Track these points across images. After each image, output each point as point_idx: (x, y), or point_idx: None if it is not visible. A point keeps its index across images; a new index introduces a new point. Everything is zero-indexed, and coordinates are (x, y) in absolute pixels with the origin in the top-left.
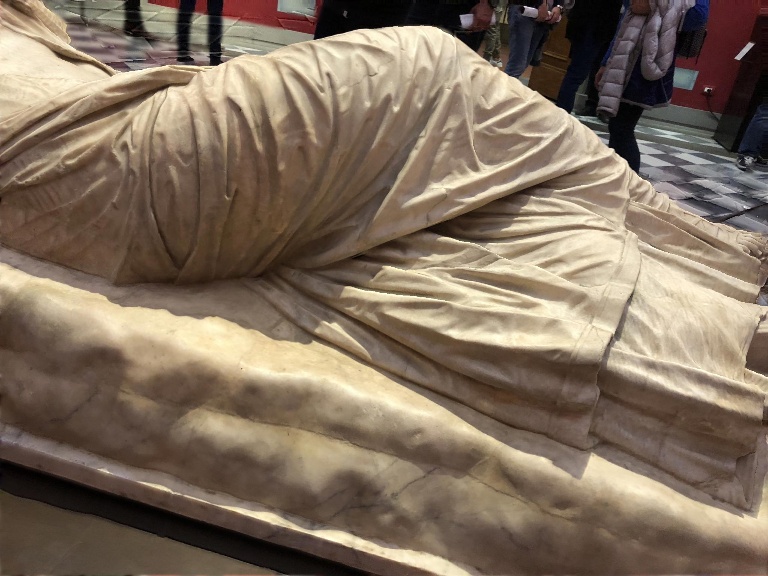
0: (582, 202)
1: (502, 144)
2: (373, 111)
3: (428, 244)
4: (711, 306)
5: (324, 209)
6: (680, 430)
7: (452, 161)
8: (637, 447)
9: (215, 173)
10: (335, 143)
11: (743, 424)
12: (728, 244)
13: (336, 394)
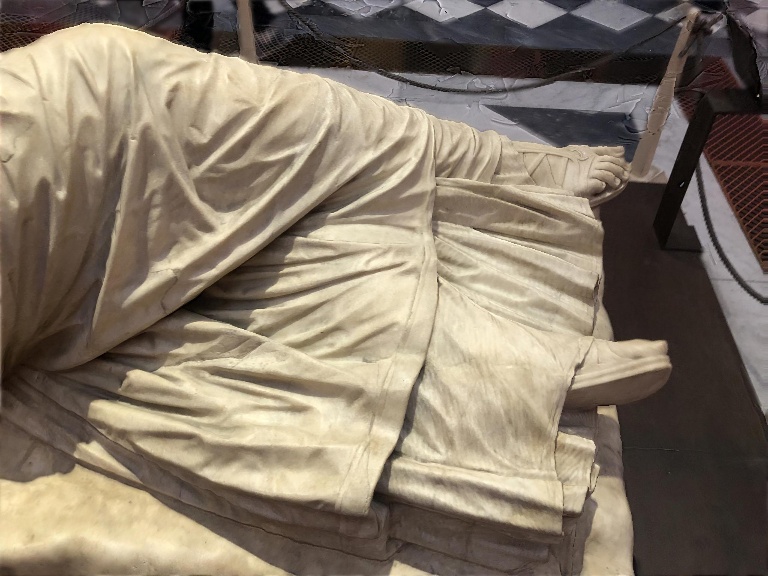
0: (368, 219)
1: (240, 180)
2: (28, 209)
3: (176, 332)
4: (515, 369)
5: (28, 323)
6: (484, 529)
7: (174, 227)
8: (442, 548)
9: None
10: None
11: (543, 536)
12: (565, 212)
13: (97, 556)
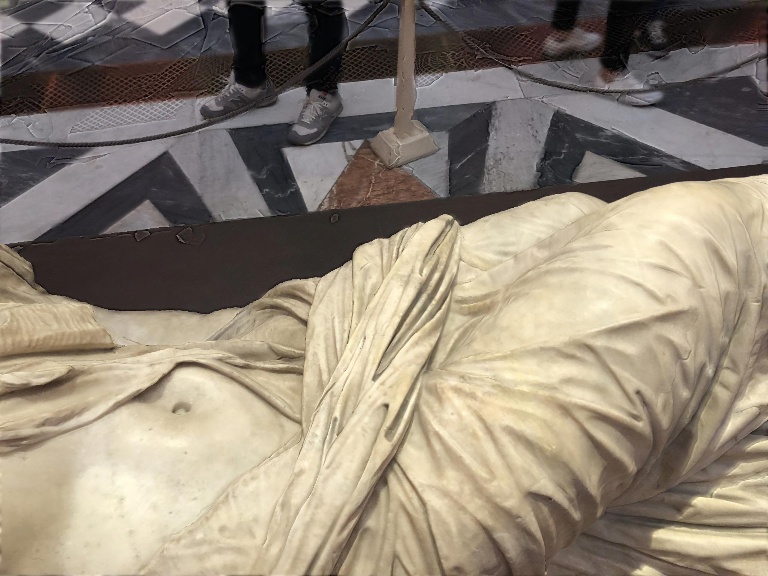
0: None
1: None
2: None
3: (733, 456)
4: None
5: None
6: None
7: (755, 367)
8: None
9: (532, 567)
10: (654, 454)
11: None
12: None
13: None
